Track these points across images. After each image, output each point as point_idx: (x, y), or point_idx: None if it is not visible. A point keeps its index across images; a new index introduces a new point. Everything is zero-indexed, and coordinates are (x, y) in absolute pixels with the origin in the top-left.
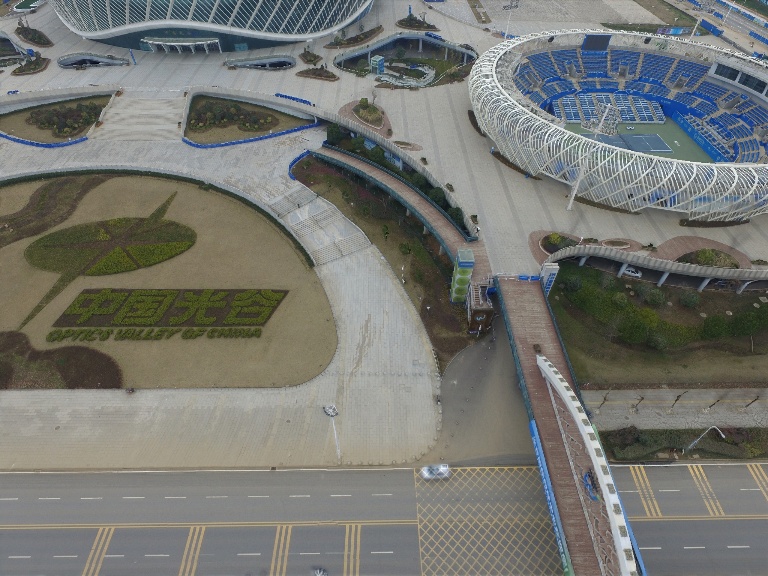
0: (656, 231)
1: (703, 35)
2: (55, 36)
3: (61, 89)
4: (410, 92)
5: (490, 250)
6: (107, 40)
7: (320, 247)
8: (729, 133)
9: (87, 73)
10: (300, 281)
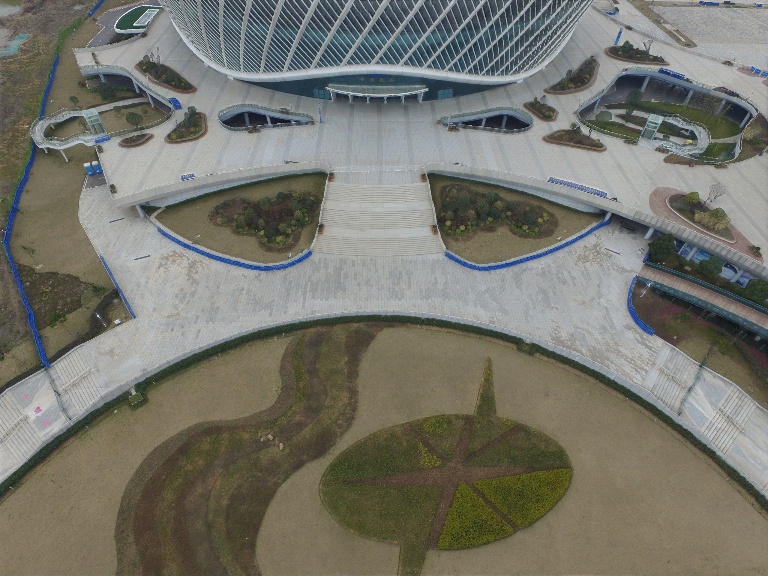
0: None
1: None
2: (191, 74)
3: (249, 169)
4: (719, 171)
5: None
6: (268, 83)
7: (767, 476)
8: None
9: (266, 138)
10: None
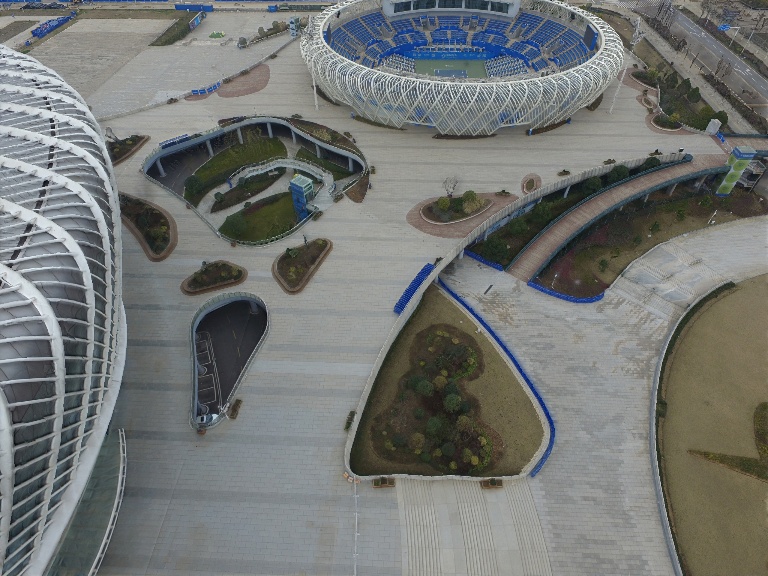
0: (620, 88)
1: (205, 15)
2: None
3: None
4: (380, 174)
5: (694, 152)
6: None
7: (705, 276)
8: (458, 40)
9: None
10: (762, 293)
